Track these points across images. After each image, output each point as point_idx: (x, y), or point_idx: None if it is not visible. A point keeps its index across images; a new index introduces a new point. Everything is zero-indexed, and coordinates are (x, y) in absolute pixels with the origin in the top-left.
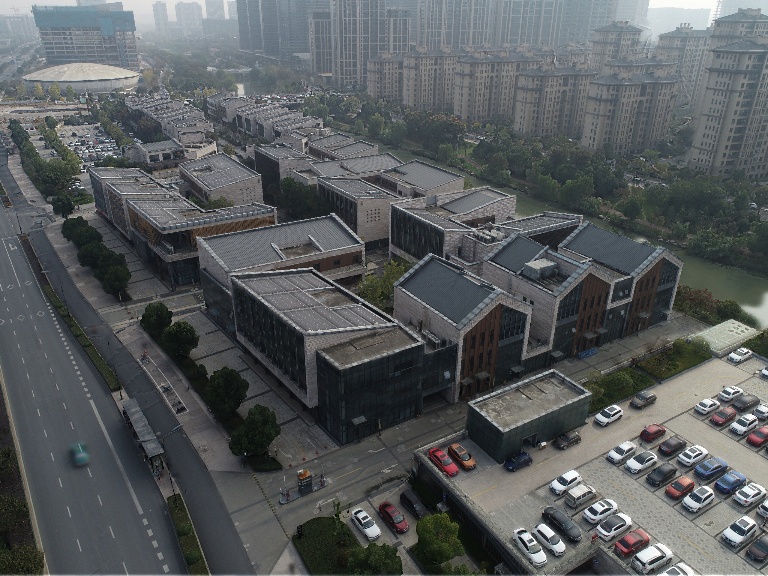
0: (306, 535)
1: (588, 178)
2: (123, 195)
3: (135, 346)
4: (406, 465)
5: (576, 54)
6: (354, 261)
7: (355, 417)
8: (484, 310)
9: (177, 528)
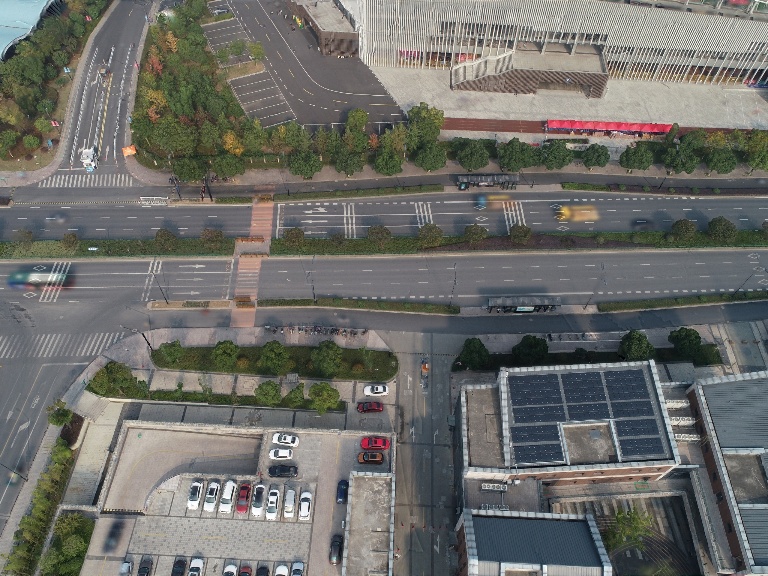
0: (388, 358)
1: None
2: None
3: None
4: (409, 445)
5: None
6: None
7: None
8: None
9: (432, 304)
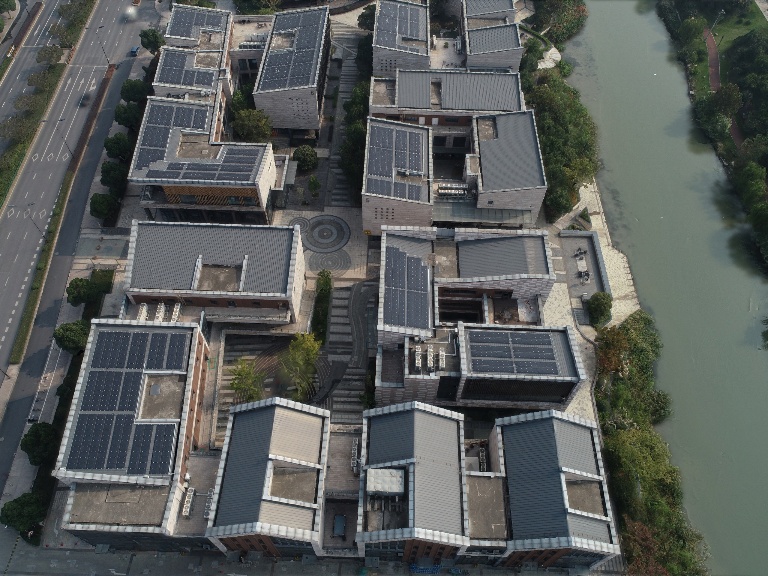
0: None
1: None
2: (154, 86)
3: (69, 304)
4: None
5: None
6: (283, 303)
7: (102, 543)
8: (236, 534)
9: None
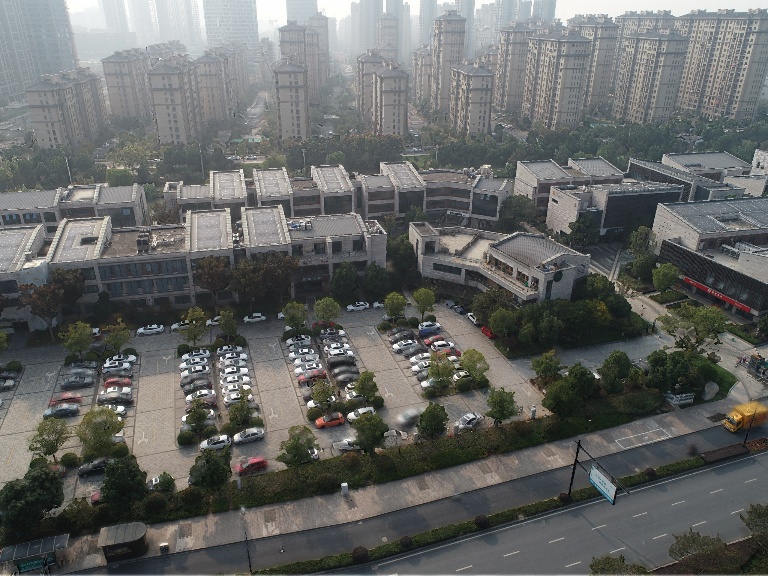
0: None
1: (613, 144)
2: None
3: None
4: None
5: (230, 56)
6: None
7: None
8: None
9: None
